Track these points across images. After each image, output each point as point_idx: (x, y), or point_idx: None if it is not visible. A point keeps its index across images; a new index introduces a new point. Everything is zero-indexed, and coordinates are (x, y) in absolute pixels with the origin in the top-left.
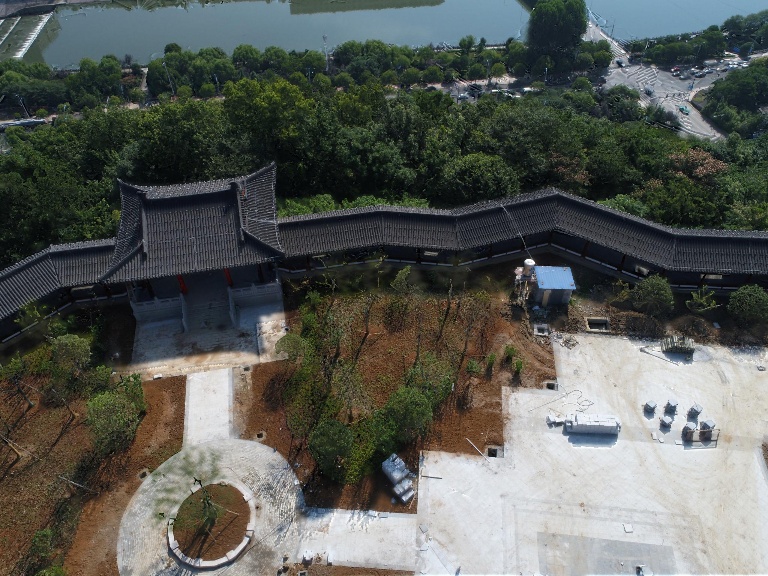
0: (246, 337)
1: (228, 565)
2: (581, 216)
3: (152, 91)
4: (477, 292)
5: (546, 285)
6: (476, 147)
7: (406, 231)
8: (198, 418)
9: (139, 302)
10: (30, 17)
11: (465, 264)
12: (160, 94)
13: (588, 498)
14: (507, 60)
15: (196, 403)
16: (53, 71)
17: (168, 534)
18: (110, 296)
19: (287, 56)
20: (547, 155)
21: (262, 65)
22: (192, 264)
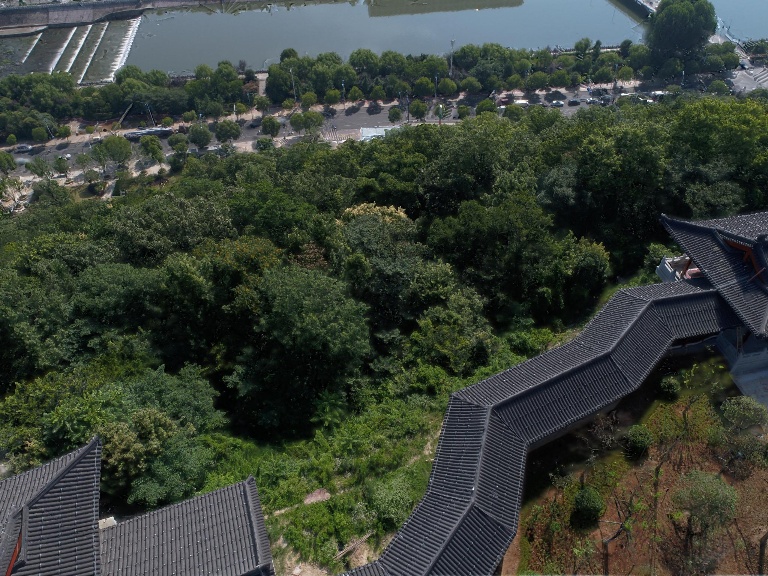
0: None
1: None
2: None
3: (274, 98)
4: None
5: None
6: None
7: None
8: None
9: (746, 353)
10: (118, 22)
11: None
12: (285, 101)
13: None
14: (629, 63)
15: None
16: (169, 78)
17: None
18: (684, 345)
19: (405, 61)
20: None
21: (380, 70)
22: None
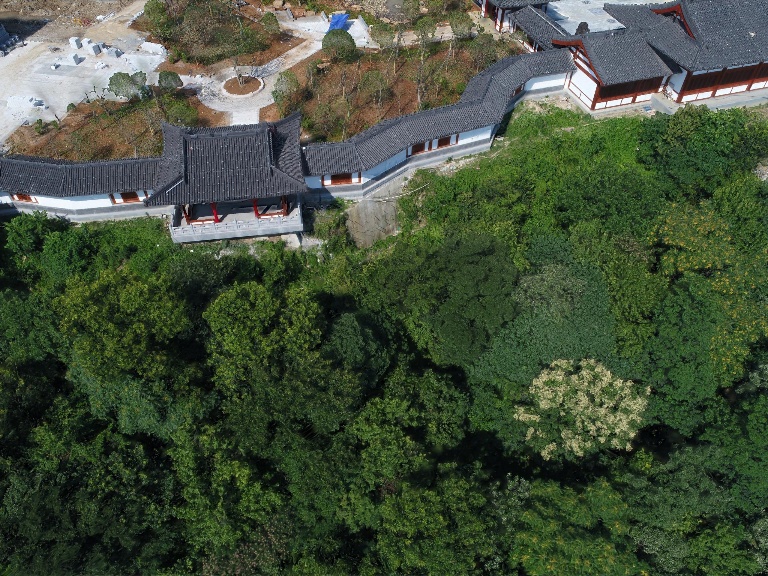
0: None
1: None
2: None
3: None
4: None
5: None
6: None
7: None
8: (251, 119)
9: None
10: None
11: None
12: None
13: (55, 85)
14: None
15: None
16: None
17: None
18: None
19: None
20: None
21: None
22: None
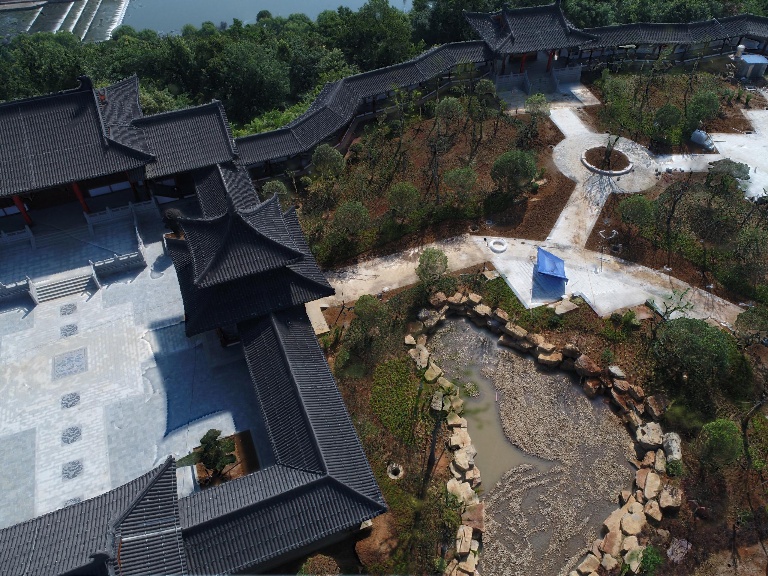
0: (568, 96)
1: (627, 174)
2: (764, 25)
3: None
4: (703, 72)
5: (751, 61)
6: (670, 1)
7: (656, 35)
8: (566, 126)
9: (501, 75)
10: None
11: (687, 61)
12: None
13: None
14: None
15: (560, 121)
16: None
17: (586, 164)
18: (471, 79)
19: None
20: (722, 2)
21: None
22: (542, 45)
